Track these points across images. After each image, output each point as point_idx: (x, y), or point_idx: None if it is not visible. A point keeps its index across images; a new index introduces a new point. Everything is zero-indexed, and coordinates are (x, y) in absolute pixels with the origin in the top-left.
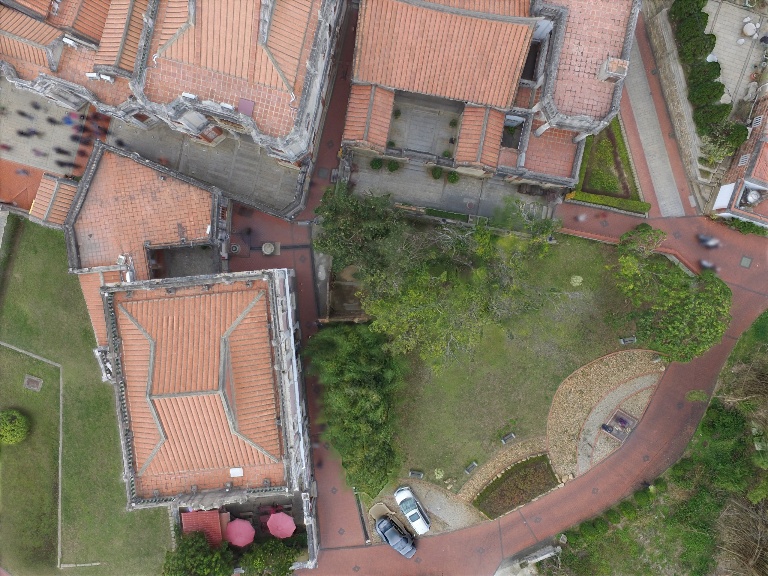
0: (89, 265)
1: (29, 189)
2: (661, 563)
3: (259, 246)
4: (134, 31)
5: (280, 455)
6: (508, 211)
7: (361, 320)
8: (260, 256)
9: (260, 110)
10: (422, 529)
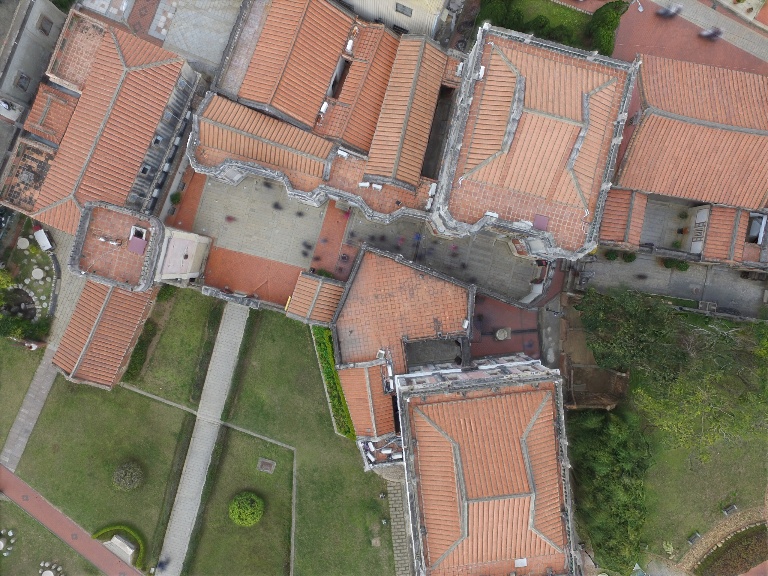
0: (350, 360)
1: (269, 282)
2: None
3: (490, 331)
4: (407, 144)
5: (563, 545)
6: (731, 295)
7: (611, 407)
8: (491, 341)
9: (553, 225)
10: None
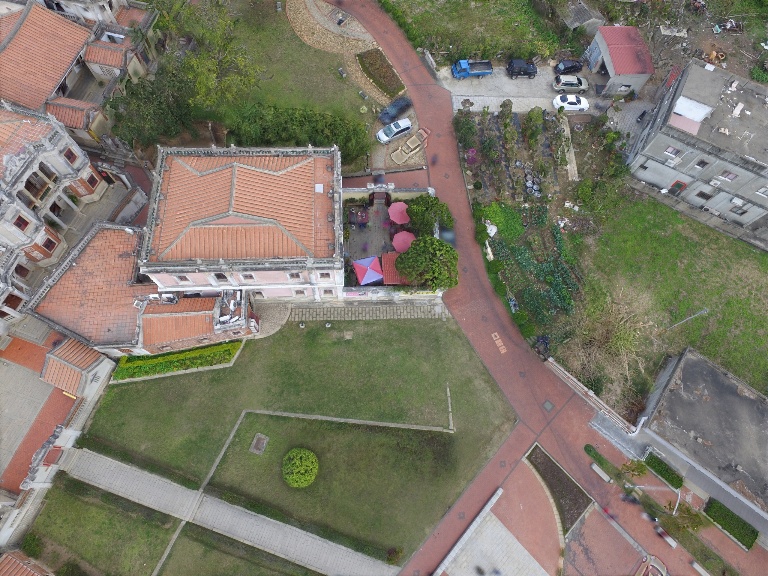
0: None
1: (58, 423)
2: (437, 3)
3: None
4: None
5: None
6: None
7: (227, 131)
8: None
9: None
10: (406, 122)
